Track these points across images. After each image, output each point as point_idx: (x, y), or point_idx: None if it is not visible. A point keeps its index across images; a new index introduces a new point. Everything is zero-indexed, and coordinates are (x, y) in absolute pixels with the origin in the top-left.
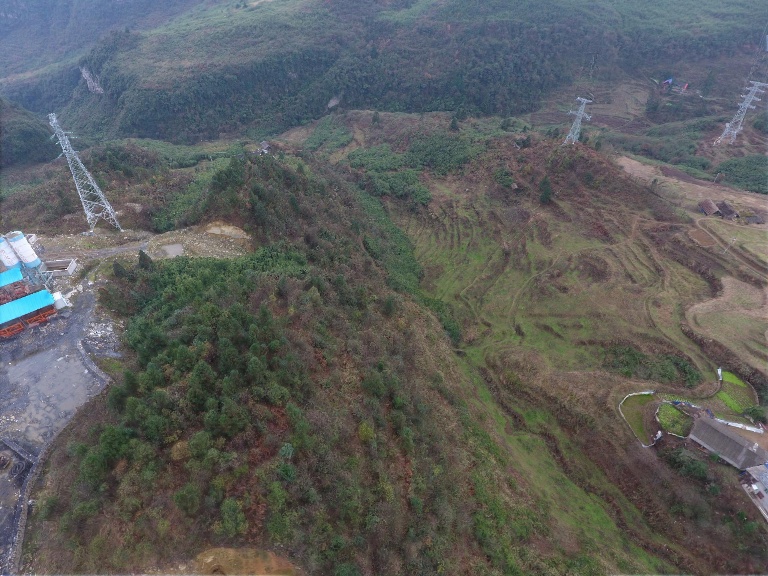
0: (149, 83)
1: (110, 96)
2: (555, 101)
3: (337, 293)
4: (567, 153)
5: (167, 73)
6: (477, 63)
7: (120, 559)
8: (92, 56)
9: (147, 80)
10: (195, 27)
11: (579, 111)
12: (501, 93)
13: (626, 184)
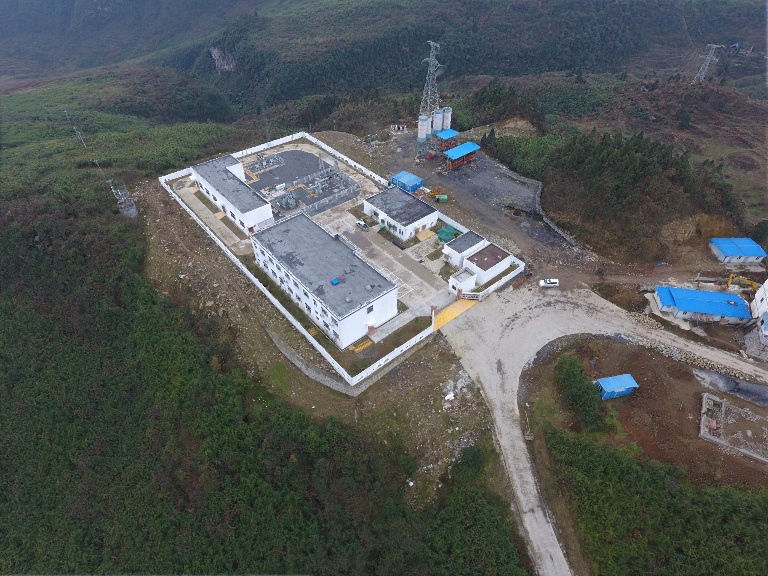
0: (291, 57)
1: (248, 71)
2: (634, 66)
3: None
4: (698, 89)
5: (305, 48)
6: (568, 34)
7: (667, 211)
8: (226, 37)
9: (288, 55)
10: (315, 10)
11: (709, 55)
12: (590, 59)
13: (754, 107)
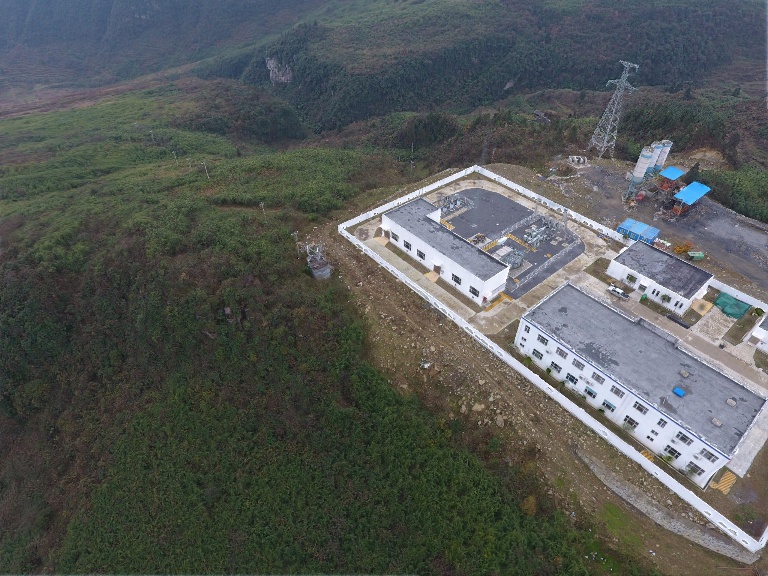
0: (358, 69)
1: (309, 83)
2: (716, 79)
3: None
4: None
5: (373, 60)
6: (650, 45)
7: None
8: (284, 47)
9: (355, 66)
10: (378, 19)
11: None
12: (672, 72)
13: None
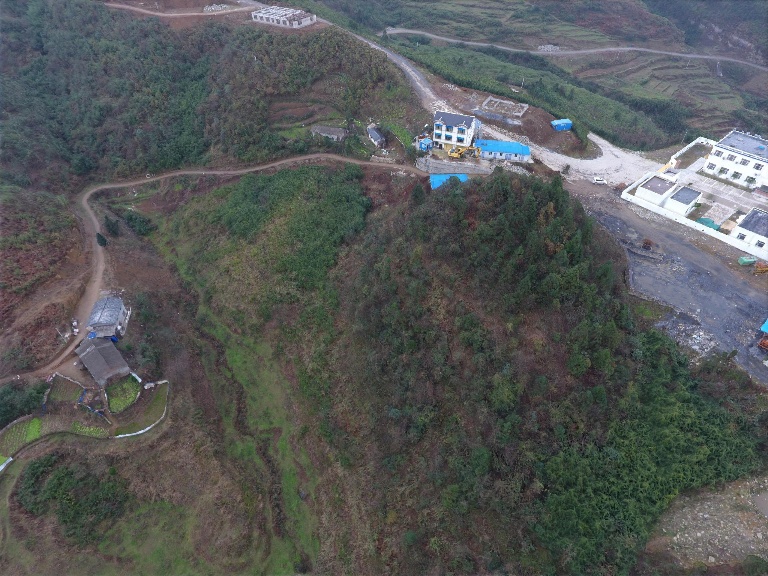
0: None
1: None
2: None
3: (482, 439)
4: None
5: None
6: None
7: None
8: None
9: None
10: None
11: None
12: None
13: None
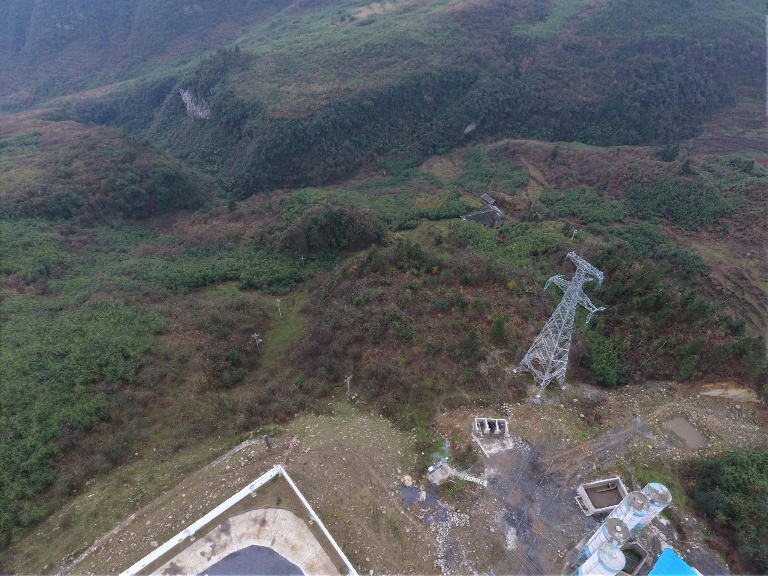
0: (280, 111)
1: (225, 124)
2: (718, 124)
3: None
4: None
5: (299, 100)
6: (639, 84)
7: None
8: (198, 78)
9: (276, 108)
10: (313, 45)
11: None
12: (666, 117)
13: None
